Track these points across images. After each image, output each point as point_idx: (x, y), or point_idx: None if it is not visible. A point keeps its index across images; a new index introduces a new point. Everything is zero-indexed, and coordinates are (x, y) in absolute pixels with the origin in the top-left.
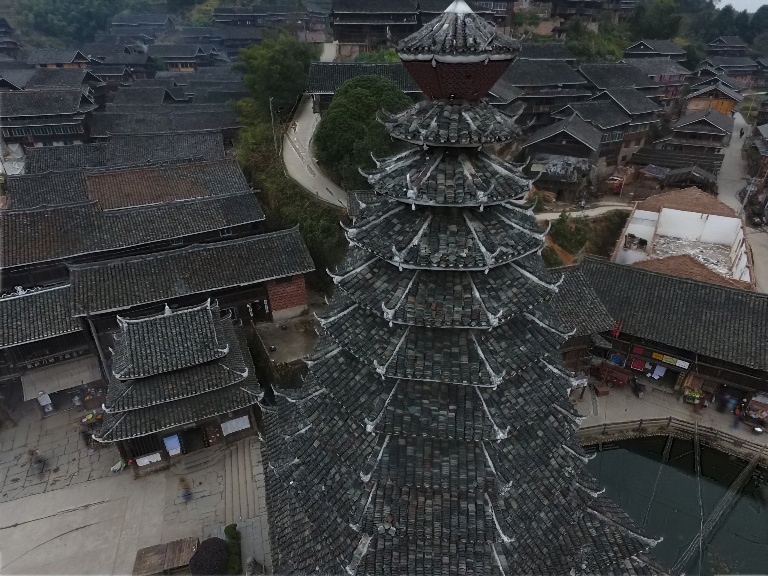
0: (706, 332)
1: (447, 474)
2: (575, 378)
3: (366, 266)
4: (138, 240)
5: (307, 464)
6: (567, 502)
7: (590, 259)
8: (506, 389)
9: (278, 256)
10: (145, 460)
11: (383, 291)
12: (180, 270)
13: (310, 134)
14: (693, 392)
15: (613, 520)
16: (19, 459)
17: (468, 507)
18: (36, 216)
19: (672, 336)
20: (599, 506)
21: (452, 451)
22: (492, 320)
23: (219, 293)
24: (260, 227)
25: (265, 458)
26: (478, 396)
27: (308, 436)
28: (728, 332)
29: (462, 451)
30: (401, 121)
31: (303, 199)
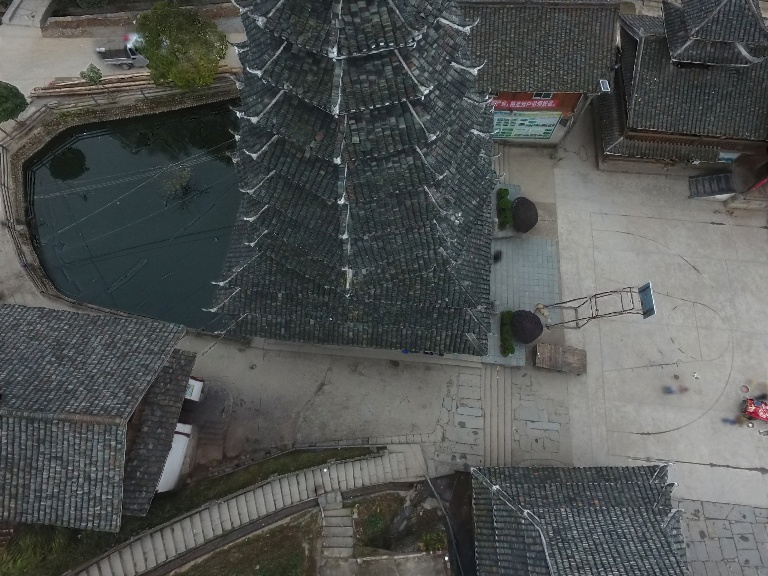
0: None
1: None
2: None
3: None
4: None
5: None
6: None
7: None
8: None
9: None
10: None
11: None
12: None
13: None
14: None
15: None
16: None
17: None
18: None
19: None
20: None
21: None
22: None
23: None
24: None
25: None
26: None
27: None
28: None
29: None
30: None
31: None
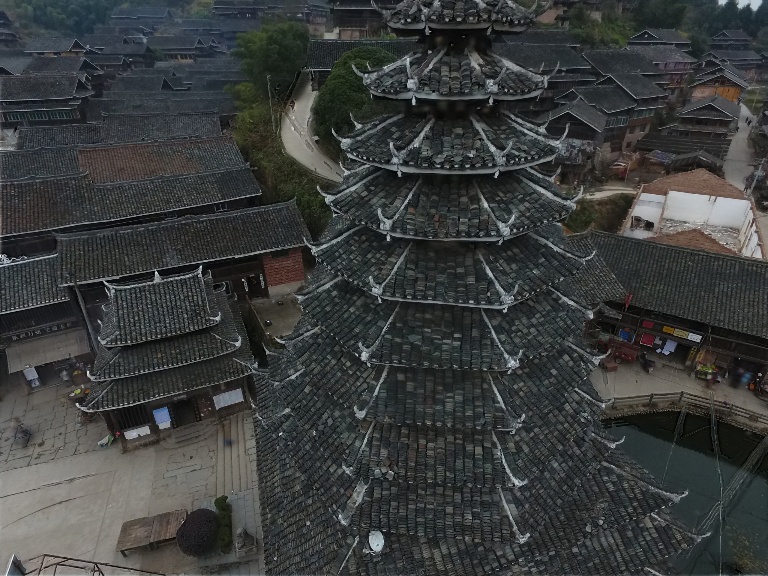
0: (719, 304)
1: (451, 410)
2: (593, 310)
3: (361, 184)
4: (130, 212)
5: (297, 410)
6: (582, 453)
7: (597, 233)
8: (517, 318)
9: (274, 229)
10: (133, 433)
11: (380, 206)
12: (172, 241)
13: (309, 112)
14: (705, 367)
15: (632, 474)
16: (3, 433)
17: (474, 450)
18: (24, 187)
19: (684, 308)
20: (616, 461)
21: (457, 387)
22: (503, 229)
23: (213, 266)
24: (256, 202)
25: (257, 424)
26: (486, 324)
27: (299, 382)
28: (743, 303)
29: (468, 387)
30: (400, 7)
31: (301, 176)
